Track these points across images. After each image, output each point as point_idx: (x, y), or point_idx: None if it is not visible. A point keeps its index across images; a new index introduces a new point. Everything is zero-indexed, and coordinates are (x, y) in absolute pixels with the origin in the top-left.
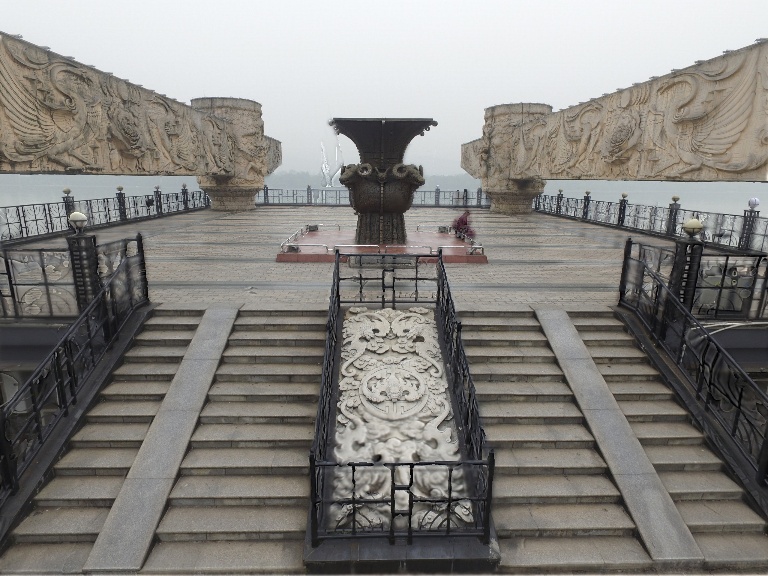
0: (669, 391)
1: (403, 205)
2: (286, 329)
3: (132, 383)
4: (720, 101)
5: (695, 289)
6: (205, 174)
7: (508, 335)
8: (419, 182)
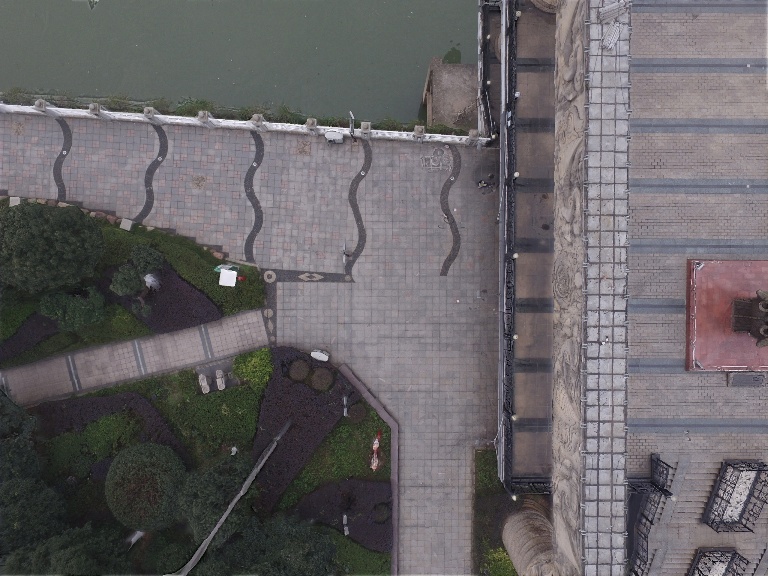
0: None
1: None
2: None
3: None
4: None
5: None
6: None
7: None
8: None
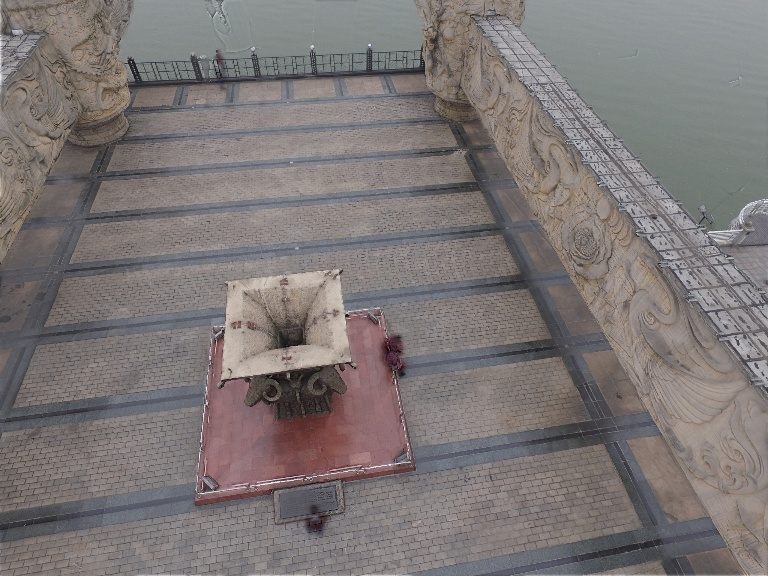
0: None
1: None
2: None
3: None
4: (689, 367)
5: None
6: (46, 176)
7: None
8: (340, 393)
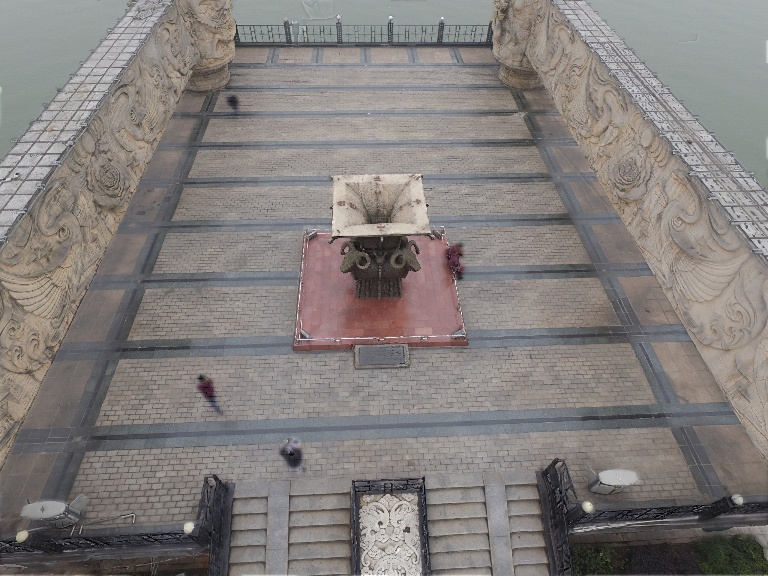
0: (546, 561)
1: (399, 277)
2: (322, 510)
3: (241, 566)
4: (707, 255)
5: None
6: None
7: (463, 510)
8: (415, 270)
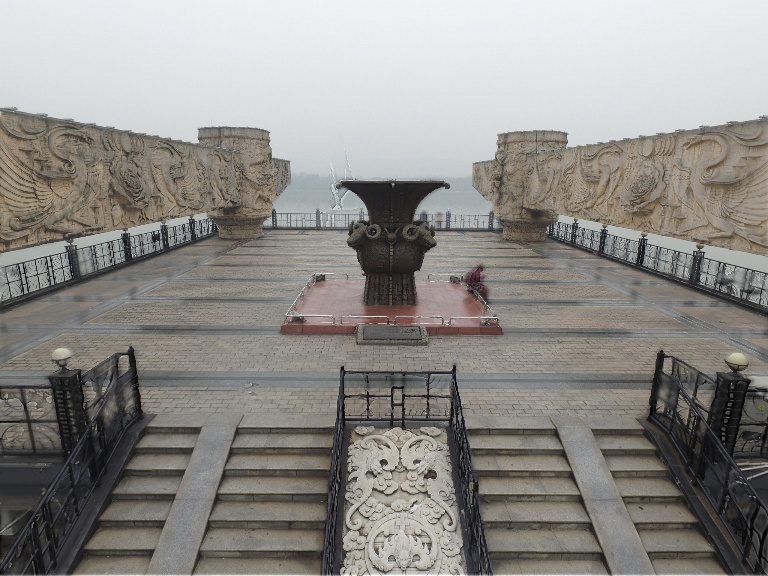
0: (710, 548)
1: (413, 266)
2: (287, 452)
3: (119, 531)
4: (754, 168)
5: (739, 427)
6: None
7: (528, 462)
8: (430, 244)
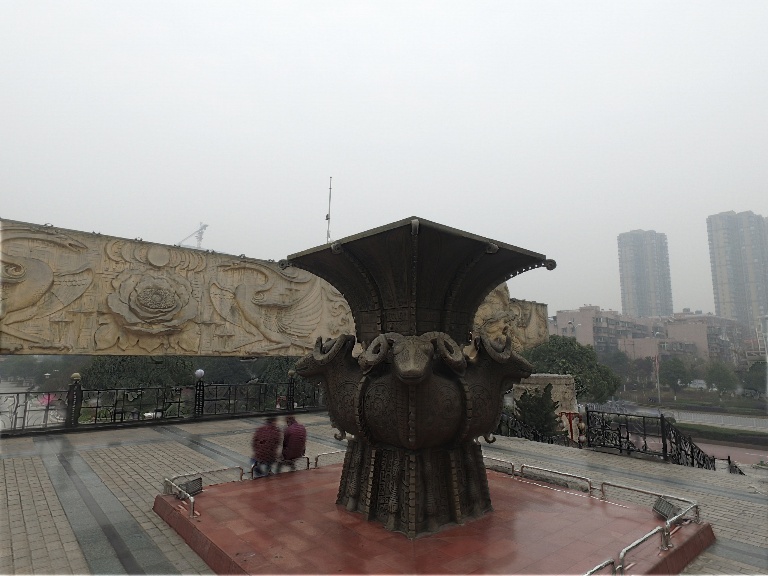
0: None
1: None
2: None
3: None
4: (296, 297)
5: None
6: None
7: None
8: None
